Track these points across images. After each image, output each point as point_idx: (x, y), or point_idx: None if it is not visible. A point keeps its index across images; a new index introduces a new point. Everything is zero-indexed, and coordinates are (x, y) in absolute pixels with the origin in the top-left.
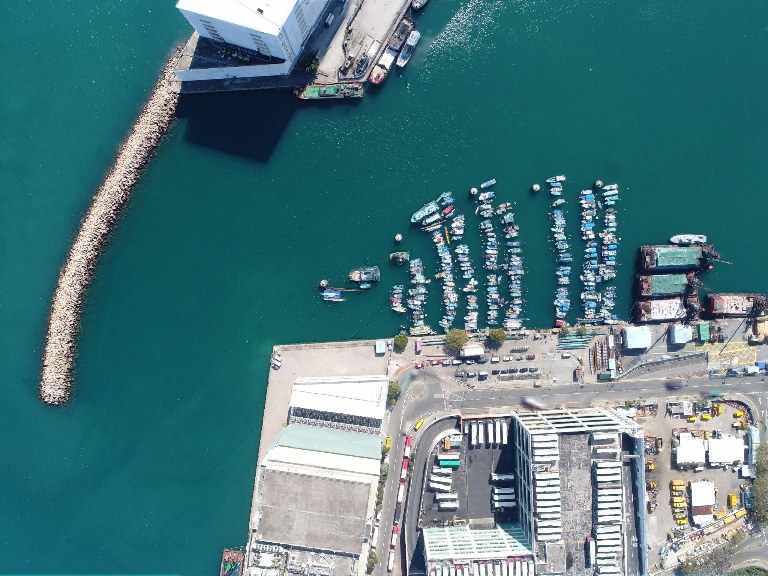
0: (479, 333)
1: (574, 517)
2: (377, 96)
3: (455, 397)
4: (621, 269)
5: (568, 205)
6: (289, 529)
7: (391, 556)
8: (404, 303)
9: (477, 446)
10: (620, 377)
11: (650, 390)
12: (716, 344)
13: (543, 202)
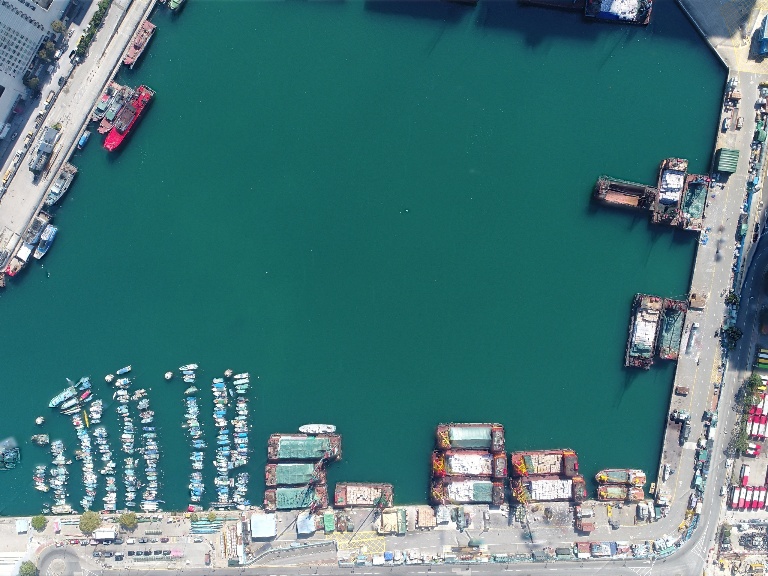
0: (116, 514)
1: None
2: (21, 284)
3: (93, 575)
4: (253, 455)
5: (202, 392)
6: None
7: None
8: (47, 483)
9: None
10: (251, 562)
11: None
12: (345, 533)
13: (176, 389)
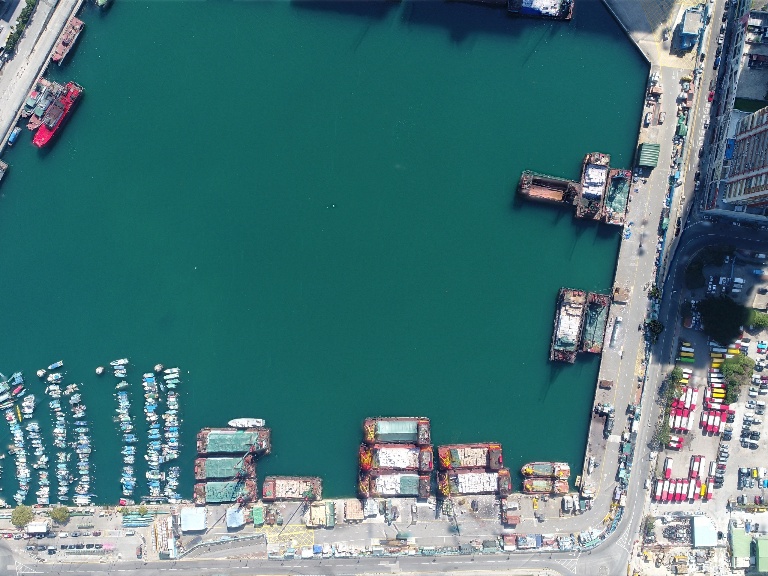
0: (49, 508)
1: None
2: None
3: (27, 569)
4: (184, 449)
5: (133, 386)
6: None
7: None
8: None
9: None
10: (182, 556)
11: (211, 569)
12: (275, 526)
13: (108, 384)
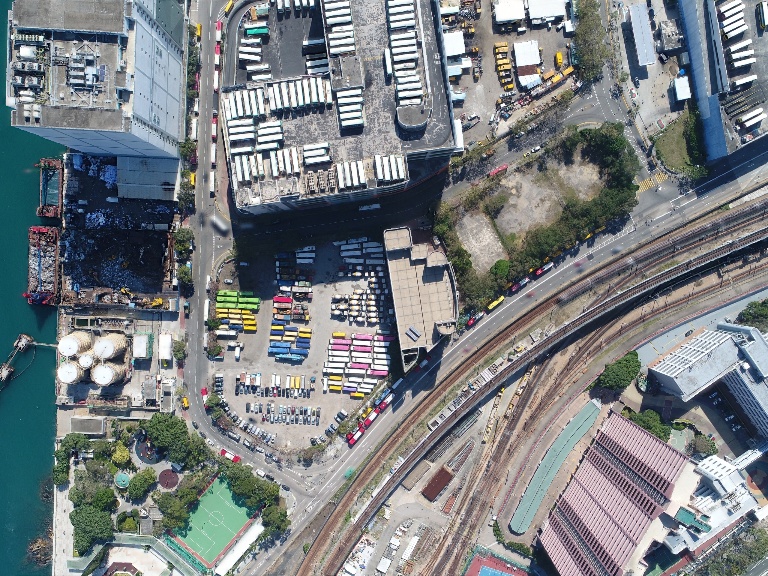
0: None
1: (369, 32)
2: None
3: None
4: None
5: None
6: (46, 12)
7: (212, 147)
8: None
9: (286, 16)
10: None
11: None
12: None
13: None
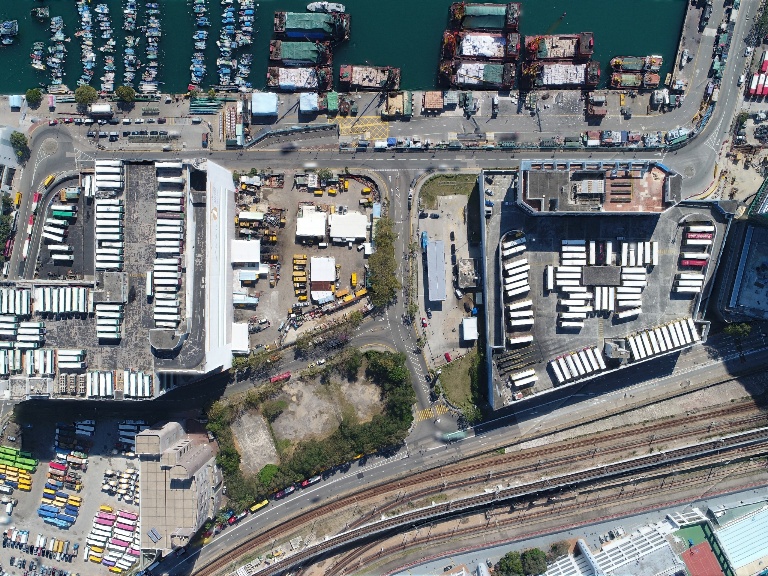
0: (113, 94)
1: (139, 250)
2: None
3: (86, 157)
4: (258, 37)
5: None
6: None
7: None
8: (44, 61)
9: None
10: (249, 146)
11: (278, 161)
12: (348, 117)
13: None
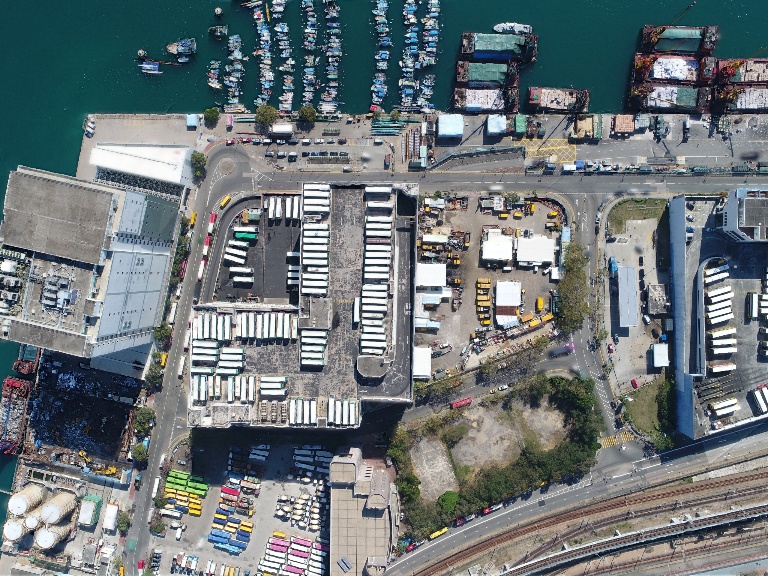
0: (292, 114)
1: (344, 275)
2: None
3: (263, 177)
4: (442, 57)
5: None
6: (30, 234)
7: (187, 333)
8: (220, 79)
9: (277, 223)
10: (432, 168)
11: (462, 183)
12: (534, 140)
13: None
